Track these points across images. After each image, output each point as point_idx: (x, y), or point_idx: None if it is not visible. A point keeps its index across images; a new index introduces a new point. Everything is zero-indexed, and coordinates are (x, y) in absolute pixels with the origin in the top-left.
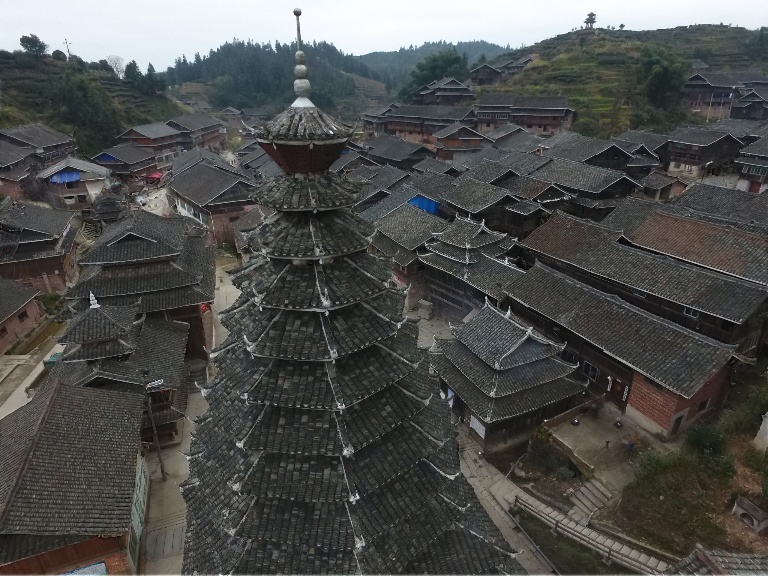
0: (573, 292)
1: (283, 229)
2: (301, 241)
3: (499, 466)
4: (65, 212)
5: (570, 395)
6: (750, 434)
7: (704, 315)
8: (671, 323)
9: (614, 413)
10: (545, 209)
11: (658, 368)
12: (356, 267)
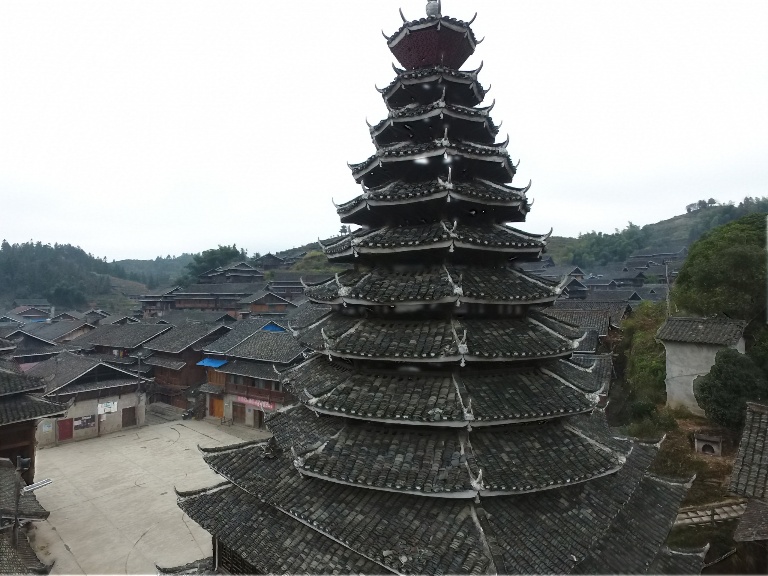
0: None
1: None
2: None
3: None
4: None
5: None
6: (661, 403)
7: None
8: None
9: None
10: None
11: None
12: None
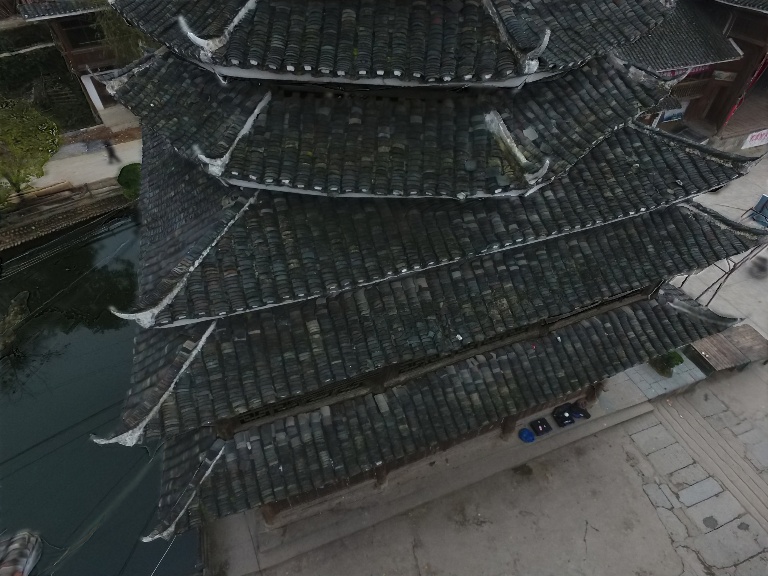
0: None
1: None
2: None
3: None
4: None
5: None
6: None
7: None
8: None
9: None
10: None
11: None
12: None
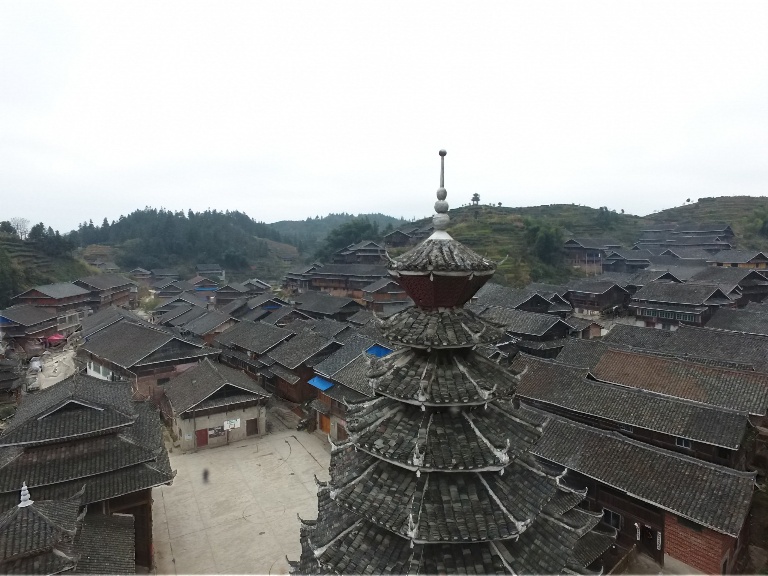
0: (570, 432)
1: (431, 371)
2: (456, 384)
3: None
4: None
5: (603, 551)
6: None
7: (699, 444)
8: (682, 455)
9: (652, 567)
10: None
11: (691, 506)
12: (500, 412)
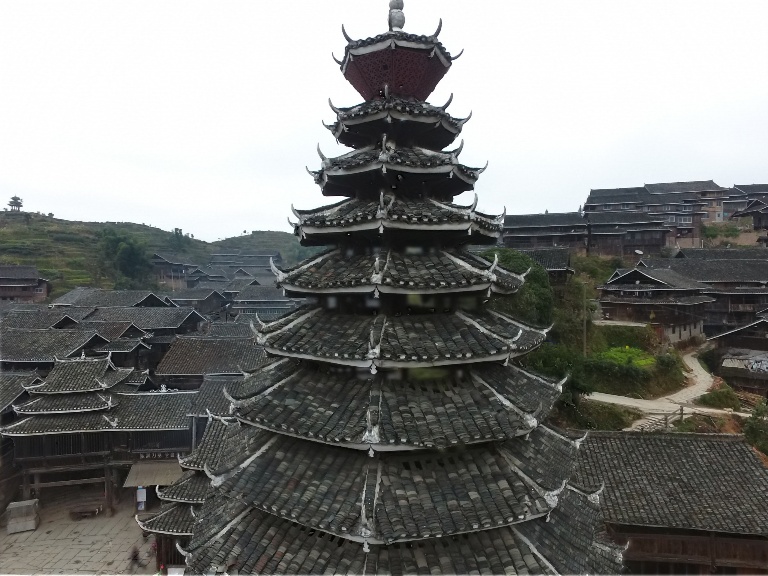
0: None
1: None
2: None
3: None
4: None
5: None
6: None
7: None
8: None
9: None
10: (145, 344)
11: None
12: None
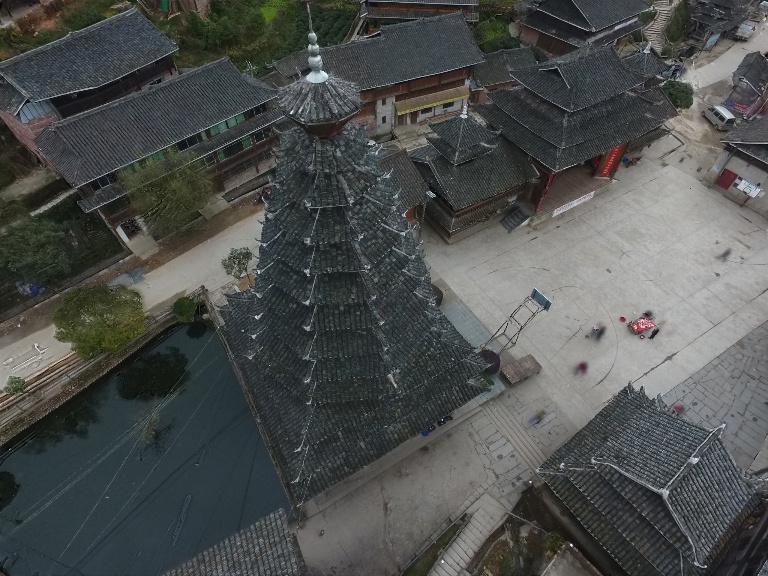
0: None
1: None
2: None
3: (529, 508)
4: (642, 3)
5: None
6: None
7: None
8: None
9: None
10: None
11: None
12: None
